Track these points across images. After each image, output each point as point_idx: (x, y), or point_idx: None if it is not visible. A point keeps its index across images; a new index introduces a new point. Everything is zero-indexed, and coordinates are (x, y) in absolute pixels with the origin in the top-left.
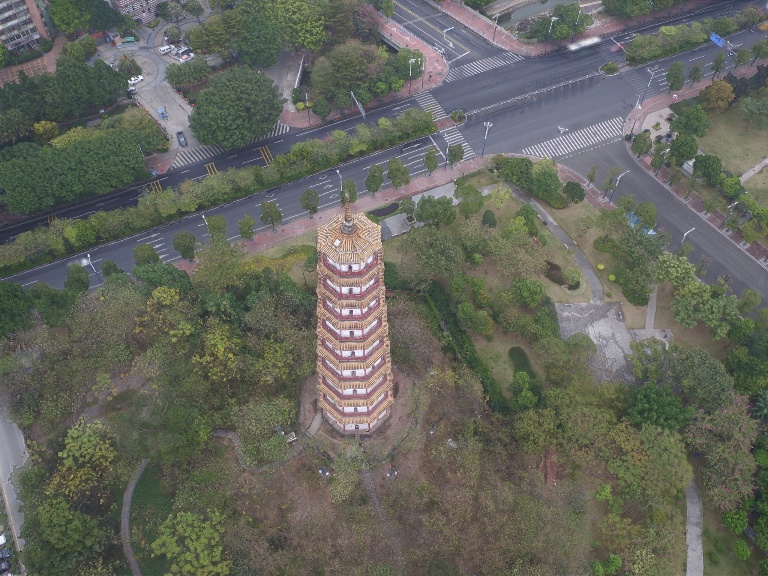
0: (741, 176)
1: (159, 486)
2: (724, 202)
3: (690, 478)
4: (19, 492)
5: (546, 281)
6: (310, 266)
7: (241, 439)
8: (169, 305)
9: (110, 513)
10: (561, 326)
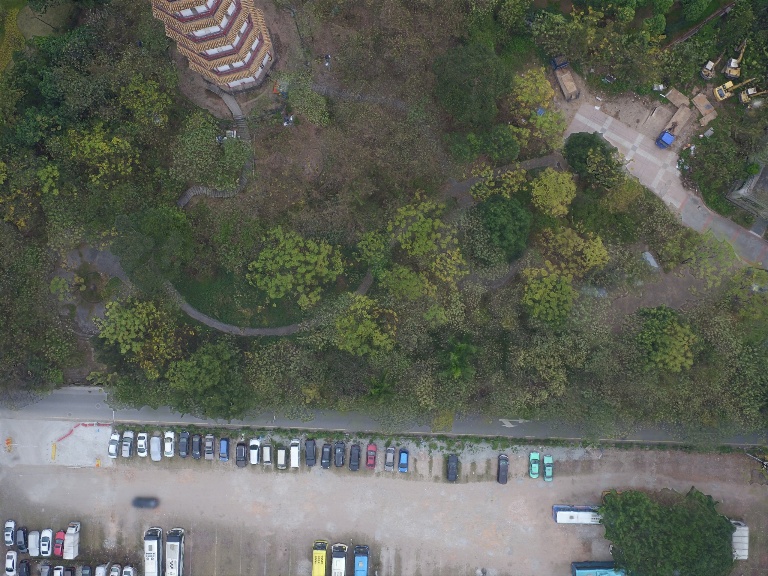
0: None
1: (200, 282)
2: None
3: None
4: (134, 405)
5: None
6: (38, 7)
7: (205, 182)
8: (6, 179)
9: (206, 331)
10: None
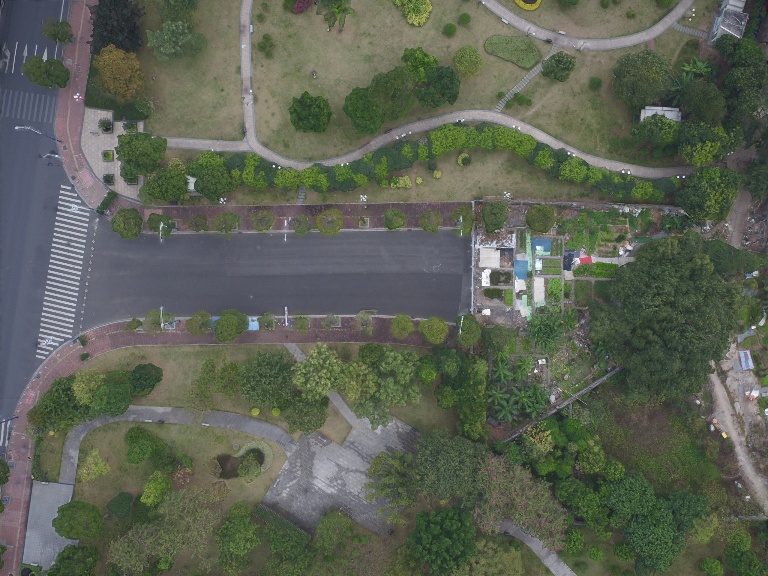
0: (245, 130)
1: None
2: (271, 216)
3: (519, 558)
4: None
5: (234, 483)
6: None
7: None
8: None
9: None
10: (295, 511)
